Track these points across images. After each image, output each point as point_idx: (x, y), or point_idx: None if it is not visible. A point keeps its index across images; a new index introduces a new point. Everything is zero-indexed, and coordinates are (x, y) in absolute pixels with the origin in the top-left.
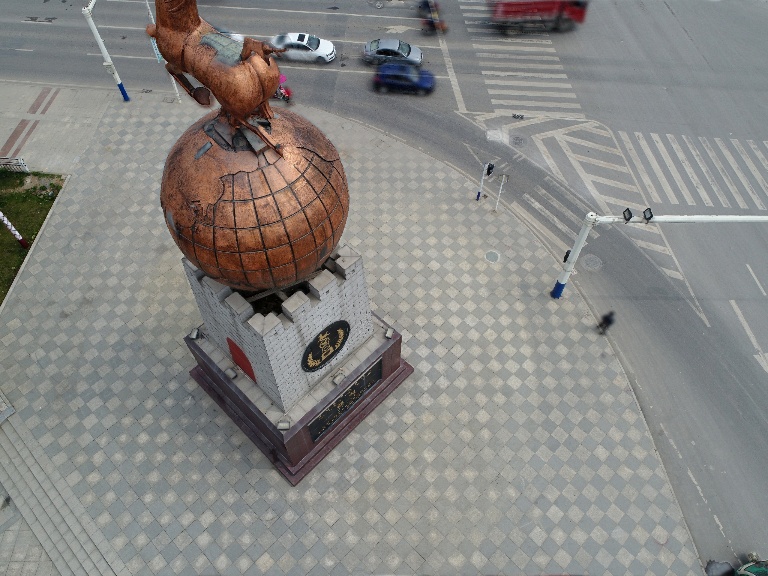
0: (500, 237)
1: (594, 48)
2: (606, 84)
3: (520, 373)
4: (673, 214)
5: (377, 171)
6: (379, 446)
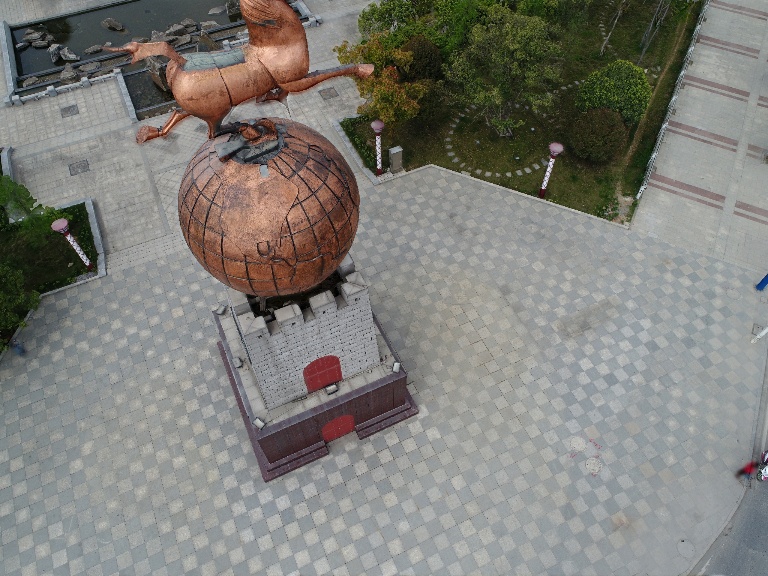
0: None
1: None
2: None
3: None
4: None
5: (579, 559)
6: (212, 421)
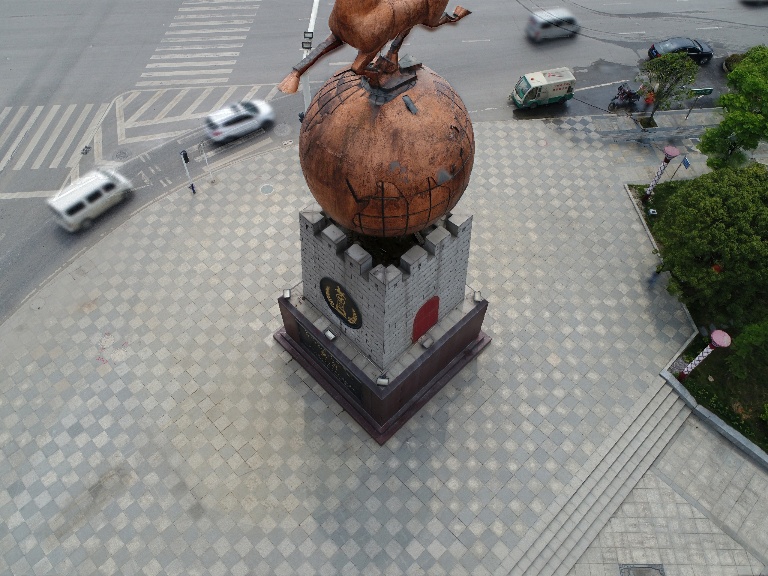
0: (245, 182)
1: (7, 79)
2: (67, 81)
3: None
4: (243, 74)
5: (128, 274)
6: None
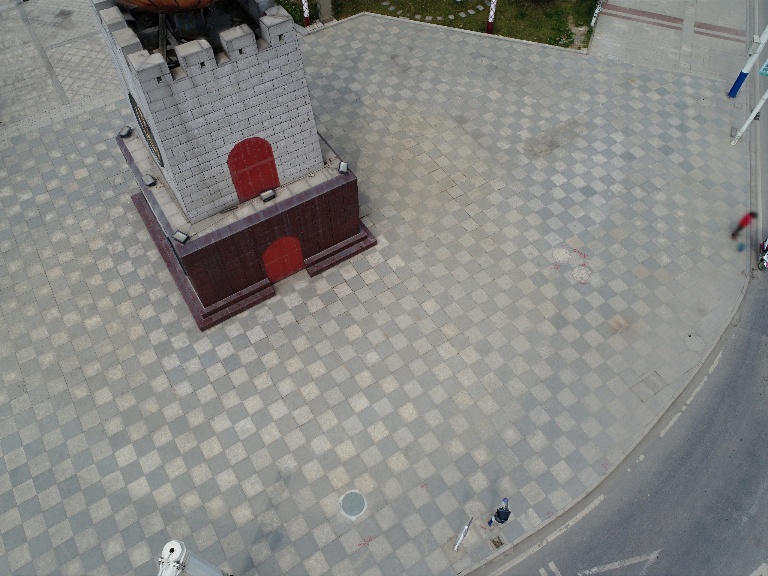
0: (392, 535)
1: None
2: None
3: (135, 469)
4: None
5: (577, 366)
6: (131, 276)
